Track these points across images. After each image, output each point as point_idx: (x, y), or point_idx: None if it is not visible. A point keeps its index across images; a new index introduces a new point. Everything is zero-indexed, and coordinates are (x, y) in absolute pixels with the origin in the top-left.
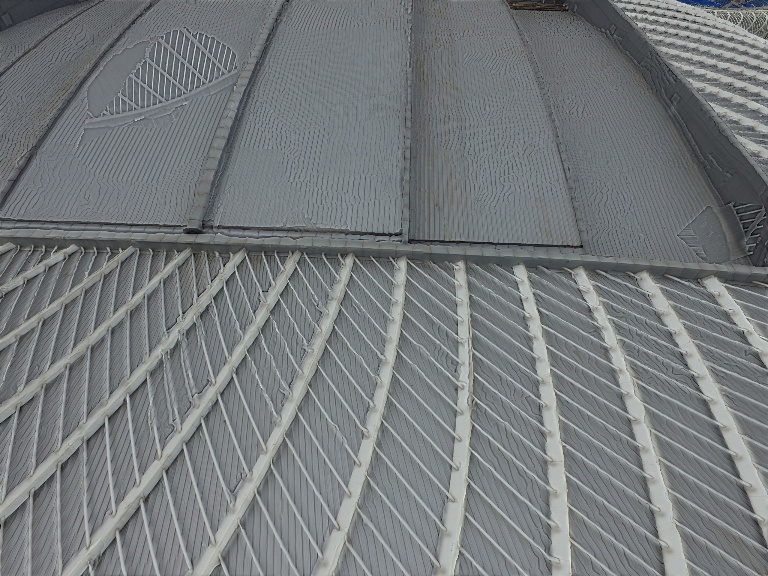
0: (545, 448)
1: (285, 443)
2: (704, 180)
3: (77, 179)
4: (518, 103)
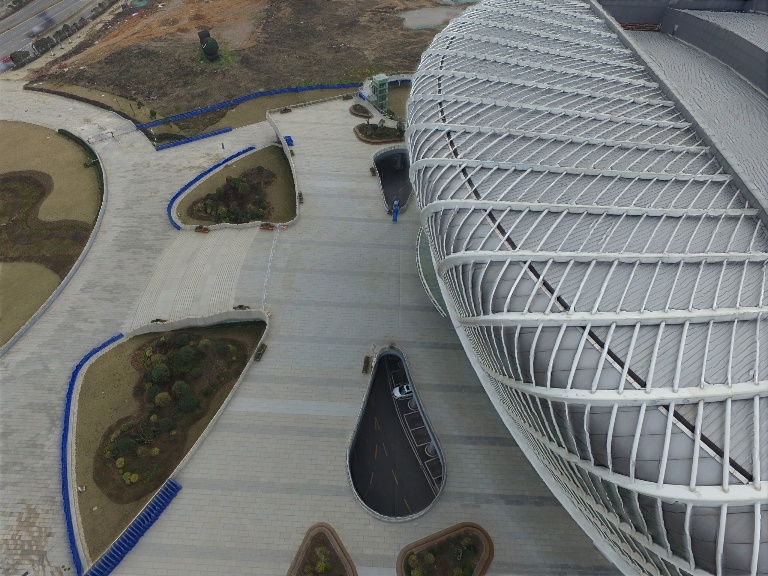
0: None
1: None
2: None
3: None
4: None
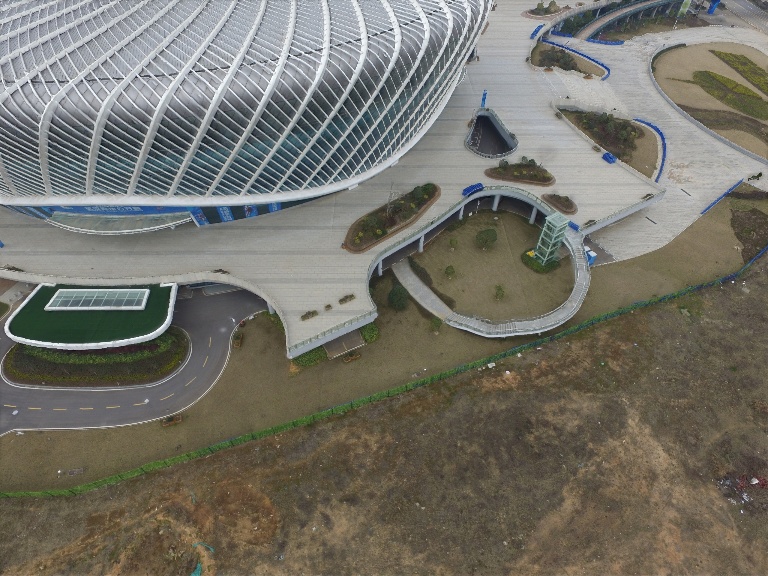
0: None
1: None
2: None
3: None
4: None
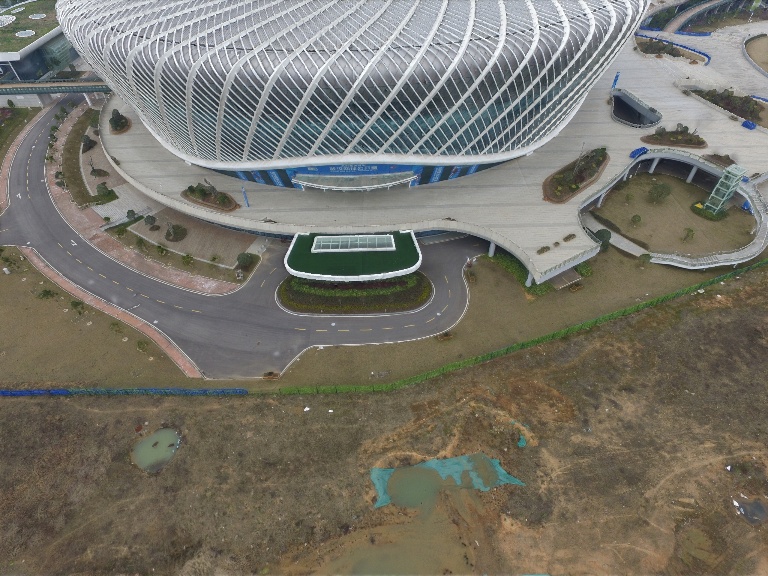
0: None
1: None
2: None
3: None
4: None
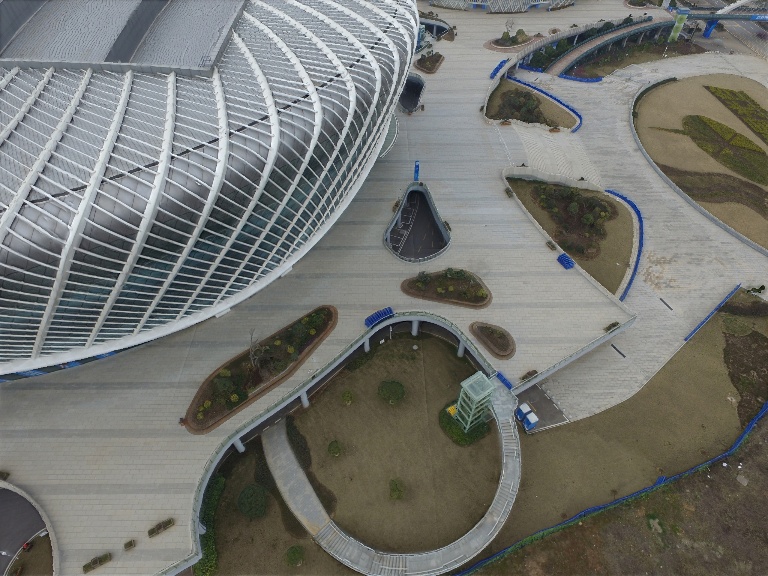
0: None
1: None
2: None
3: None
4: (121, 3)
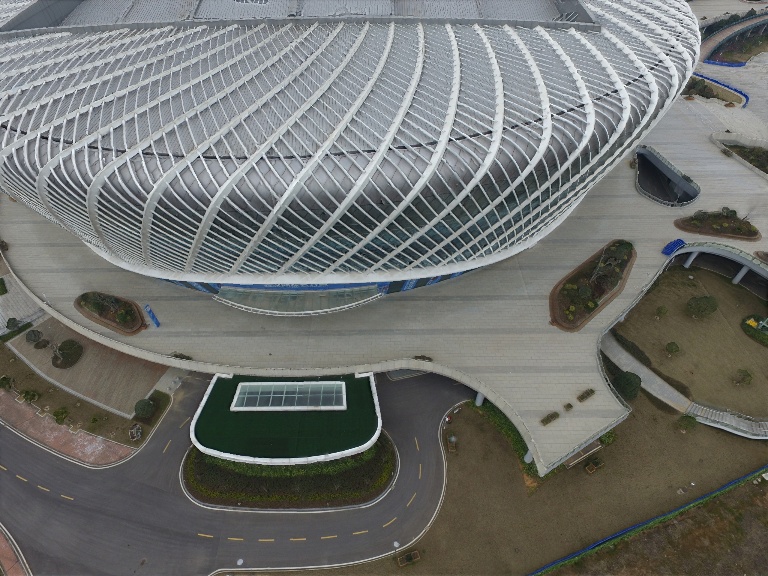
0: (453, 64)
1: (348, 65)
2: (555, 10)
3: (226, 6)
4: None
